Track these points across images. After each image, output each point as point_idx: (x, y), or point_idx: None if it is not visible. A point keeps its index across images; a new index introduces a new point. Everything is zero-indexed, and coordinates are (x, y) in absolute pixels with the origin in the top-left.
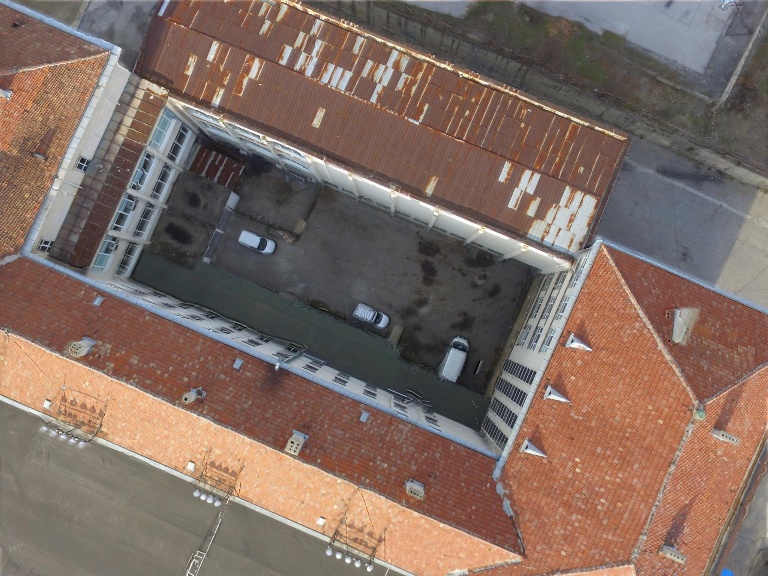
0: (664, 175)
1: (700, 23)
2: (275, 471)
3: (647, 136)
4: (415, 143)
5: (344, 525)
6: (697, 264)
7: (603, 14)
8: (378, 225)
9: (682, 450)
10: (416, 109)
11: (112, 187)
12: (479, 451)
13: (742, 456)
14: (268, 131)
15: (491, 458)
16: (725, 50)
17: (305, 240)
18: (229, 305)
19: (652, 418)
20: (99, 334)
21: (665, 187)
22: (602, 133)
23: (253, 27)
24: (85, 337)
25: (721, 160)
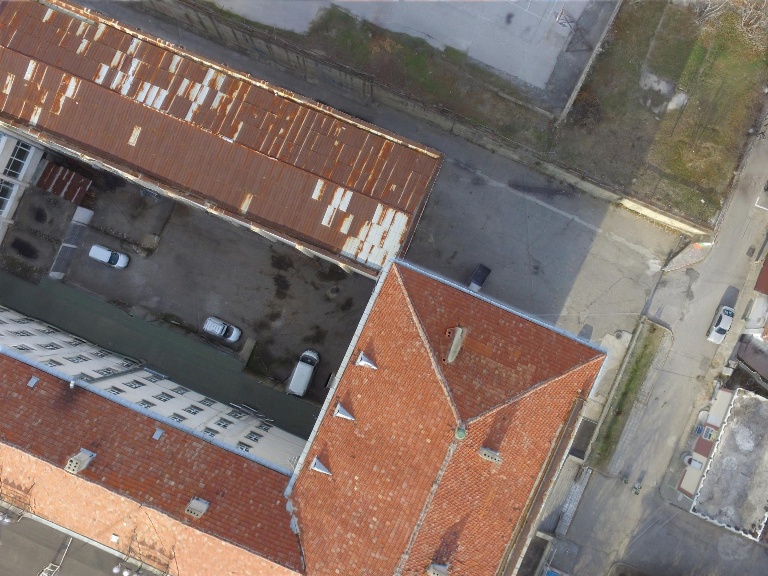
0: (516, 189)
1: (541, 39)
2: (63, 489)
3: (498, 150)
4: (229, 161)
5: (136, 542)
6: (548, 277)
7: (445, 30)
8: (231, 239)
9: (444, 469)
10: (231, 127)
11: None
12: (273, 468)
13: (525, 474)
14: (86, 149)
15: (285, 475)
16: (566, 66)
17: (159, 254)
18: (72, 320)
19: (422, 437)
20: None
21: (517, 201)
22: (415, 151)
23: (71, 46)
24: None
25: (567, 174)
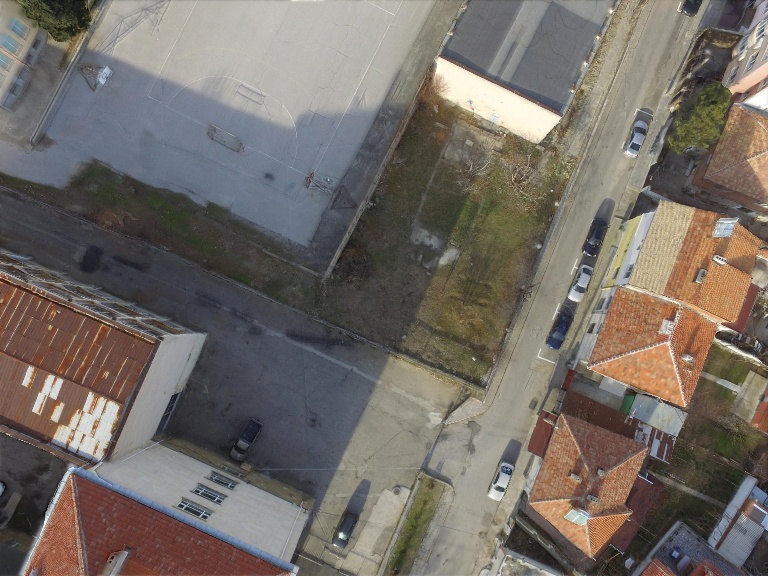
0: (293, 339)
1: (305, 196)
2: None
3: None
4: None
5: None
6: (325, 431)
7: (208, 187)
8: None
9: None
10: None
11: None
12: None
13: None
14: None
15: None
16: (331, 223)
17: None
18: None
19: None
20: None
21: (294, 351)
22: (131, 336)
23: None
24: None
25: None
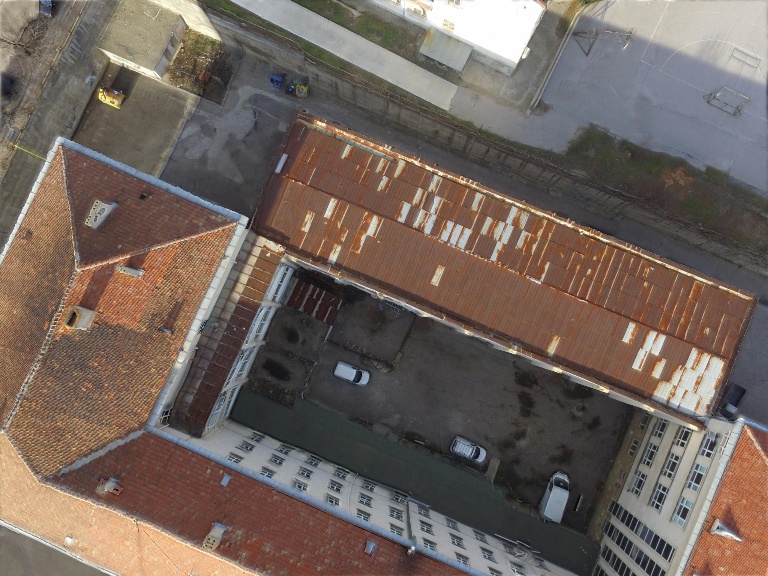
0: (764, 304)
1: None
2: None
3: (746, 265)
4: (537, 302)
5: None
6: None
7: (705, 150)
8: (474, 355)
9: None
10: (537, 267)
11: (228, 346)
12: None
13: None
14: (386, 288)
15: None
16: None
17: (399, 370)
18: (329, 446)
19: None
20: (228, 519)
21: (765, 316)
22: (727, 292)
23: (371, 183)
24: (214, 523)
25: None
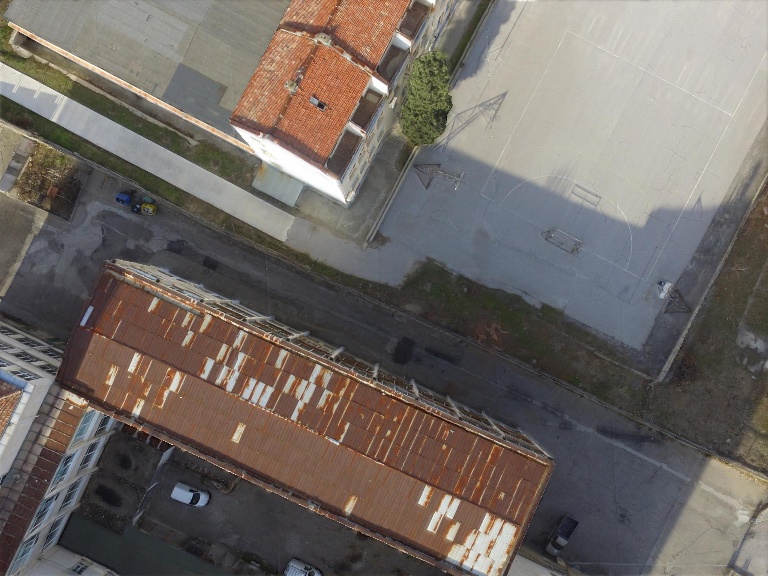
0: (604, 435)
1: (639, 300)
2: None
3: (587, 397)
4: (335, 462)
5: None
6: (635, 526)
7: (542, 288)
8: None
9: None
10: (337, 428)
11: (29, 498)
12: None
13: None
14: (188, 443)
15: None
16: (664, 327)
17: (240, 491)
18: (156, 574)
19: None
20: None
21: (604, 447)
22: (525, 457)
23: (176, 338)
24: None
25: None
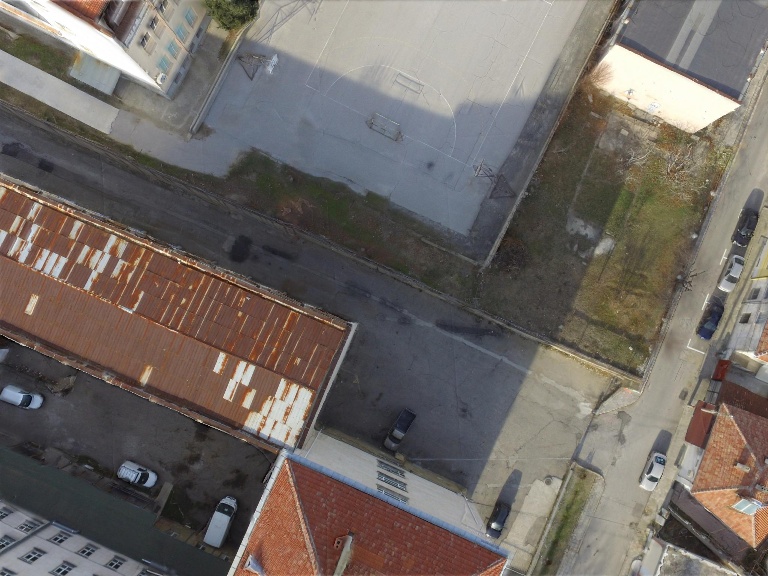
0: (443, 329)
1: (464, 185)
2: None
3: (424, 290)
4: (129, 332)
5: None
6: (476, 421)
7: (367, 175)
8: None
9: None
10: (131, 297)
11: None
12: None
13: None
14: None
15: None
16: (490, 212)
17: (74, 394)
18: None
19: None
20: None
21: (444, 341)
22: (321, 322)
23: None
24: None
25: None
